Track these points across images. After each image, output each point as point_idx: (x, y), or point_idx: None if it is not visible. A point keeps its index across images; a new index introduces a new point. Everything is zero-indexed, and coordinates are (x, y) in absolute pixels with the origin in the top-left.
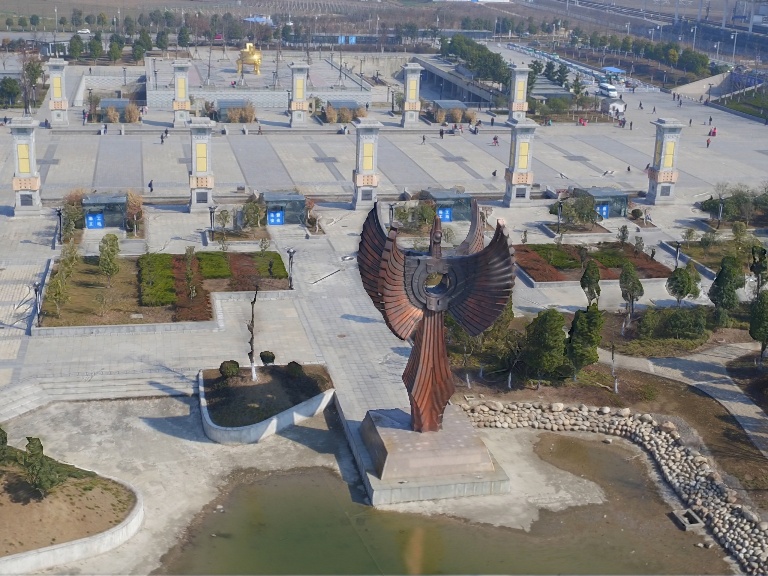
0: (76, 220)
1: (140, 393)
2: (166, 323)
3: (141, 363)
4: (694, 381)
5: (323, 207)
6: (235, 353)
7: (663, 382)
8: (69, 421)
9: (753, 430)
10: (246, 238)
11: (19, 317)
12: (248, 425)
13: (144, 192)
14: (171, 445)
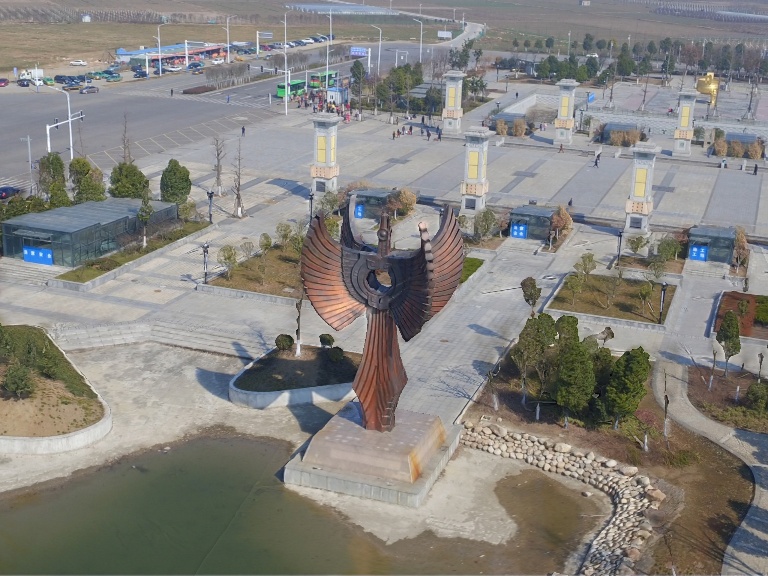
0: (342, 208)
1: (217, 349)
2: (303, 300)
3: (247, 327)
4: (757, 462)
5: (594, 230)
6: None
7: (719, 454)
8: (144, 358)
9: (751, 525)
10: (474, 245)
11: (208, 275)
12: (257, 391)
13: (444, 195)
14: (193, 394)
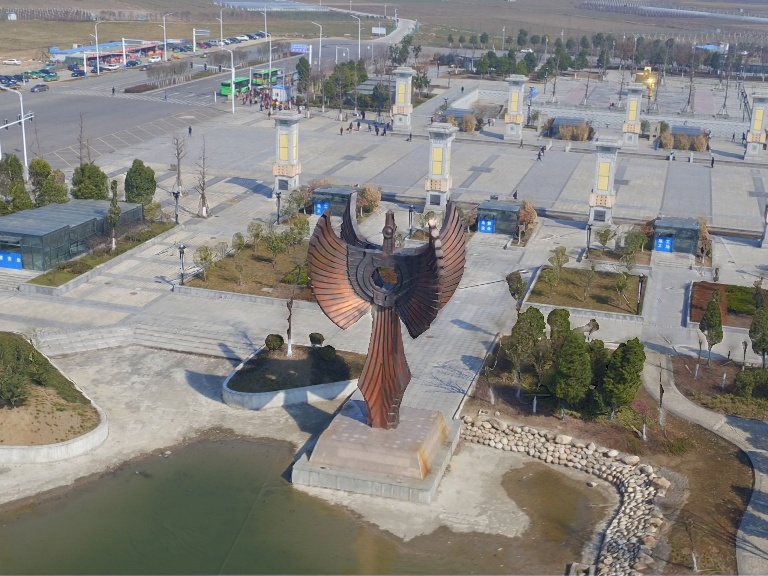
0: (308, 206)
1: (204, 351)
2: (283, 299)
3: (230, 327)
4: (752, 447)
5: (558, 223)
6: None
7: (714, 441)
8: (130, 361)
9: (757, 508)
10: None
11: None
12: (252, 392)
13: (405, 191)
14: (186, 396)
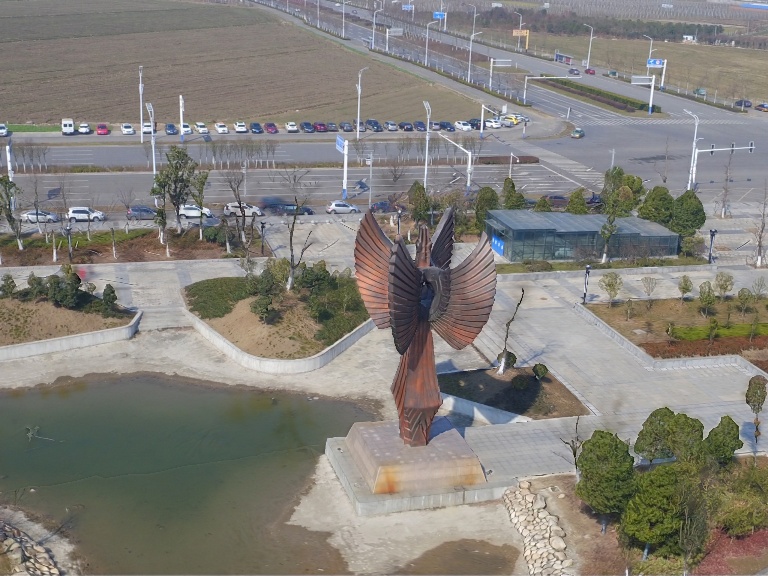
0: None
1: (488, 352)
2: (631, 342)
3: (543, 345)
4: None
5: None
6: (594, 377)
7: None
8: None
9: None
10: None
11: None
12: None
13: None
14: None
